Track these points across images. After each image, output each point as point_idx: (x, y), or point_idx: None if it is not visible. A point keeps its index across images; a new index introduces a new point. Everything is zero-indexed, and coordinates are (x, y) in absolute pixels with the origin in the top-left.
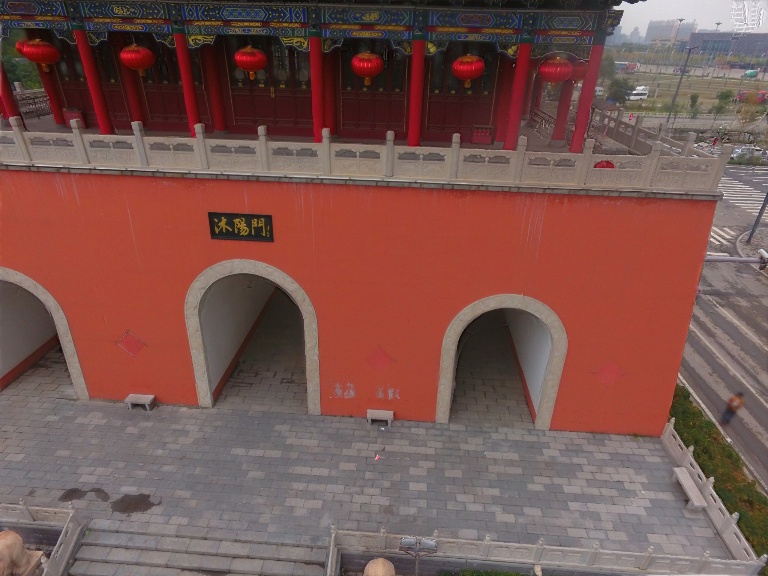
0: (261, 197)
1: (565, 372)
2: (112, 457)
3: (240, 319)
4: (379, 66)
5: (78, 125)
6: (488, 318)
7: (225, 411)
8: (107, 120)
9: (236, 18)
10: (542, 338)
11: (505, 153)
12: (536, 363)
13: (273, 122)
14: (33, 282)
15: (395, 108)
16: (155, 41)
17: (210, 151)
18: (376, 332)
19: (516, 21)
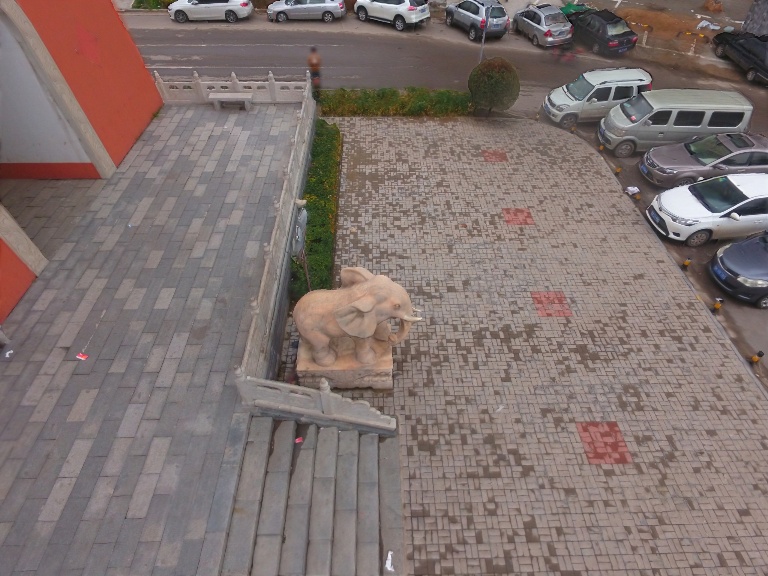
0: None
1: (61, 68)
2: None
3: None
4: None
5: None
6: None
7: None
8: None
9: None
10: None
11: None
12: (8, 106)
13: None
14: None
15: None
16: None
17: None
18: None
19: None
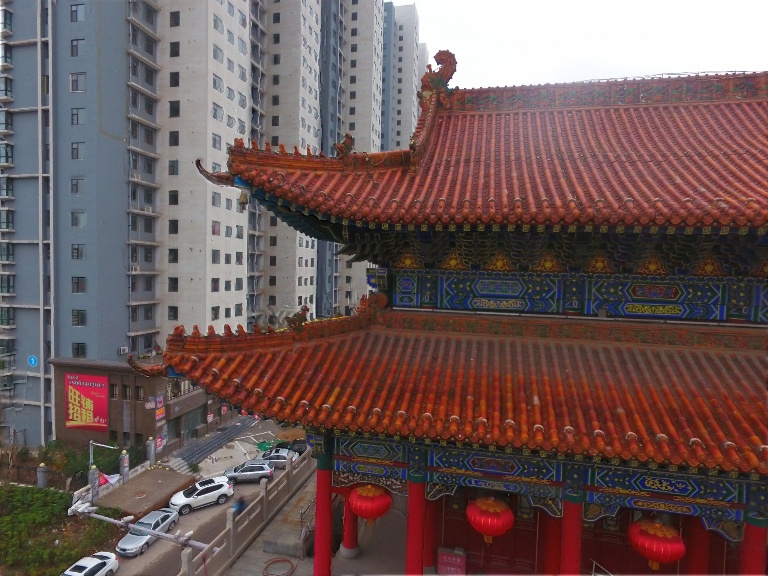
0: None
1: None
2: None
3: None
4: None
5: None
6: None
7: None
8: None
9: None
10: None
11: None
12: None
13: None
14: None
15: None
16: None
17: None
18: None
19: None
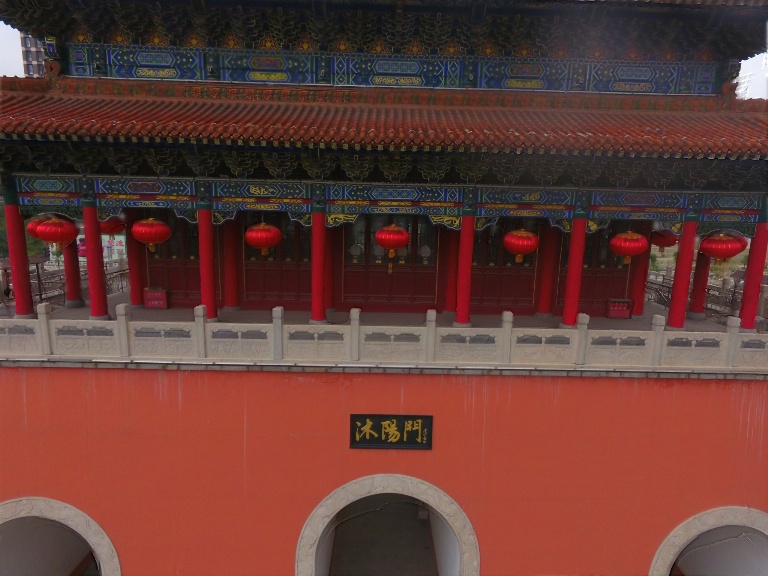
0: (422, 393)
1: None
2: None
3: (327, 541)
4: (537, 244)
5: (204, 313)
6: (705, 540)
7: None
8: (213, 302)
9: (385, 198)
10: (754, 559)
11: (715, 335)
12: None
13: (387, 299)
14: (86, 518)
15: (523, 283)
16: (289, 220)
17: (364, 340)
18: (557, 567)
19: (681, 201)
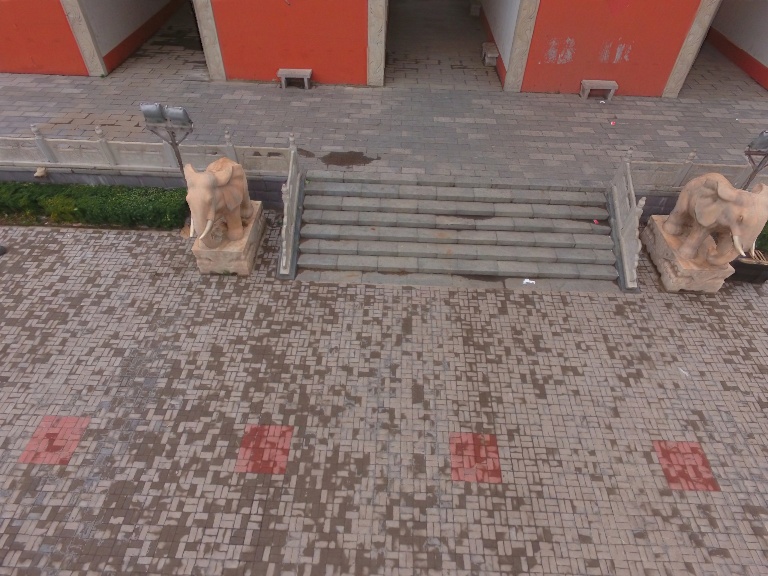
0: None
1: None
2: (292, 124)
3: None
4: None
5: None
6: None
7: (401, 89)
8: None
9: None
10: None
11: None
12: None
13: None
14: None
15: None
16: None
17: None
18: None
19: None
